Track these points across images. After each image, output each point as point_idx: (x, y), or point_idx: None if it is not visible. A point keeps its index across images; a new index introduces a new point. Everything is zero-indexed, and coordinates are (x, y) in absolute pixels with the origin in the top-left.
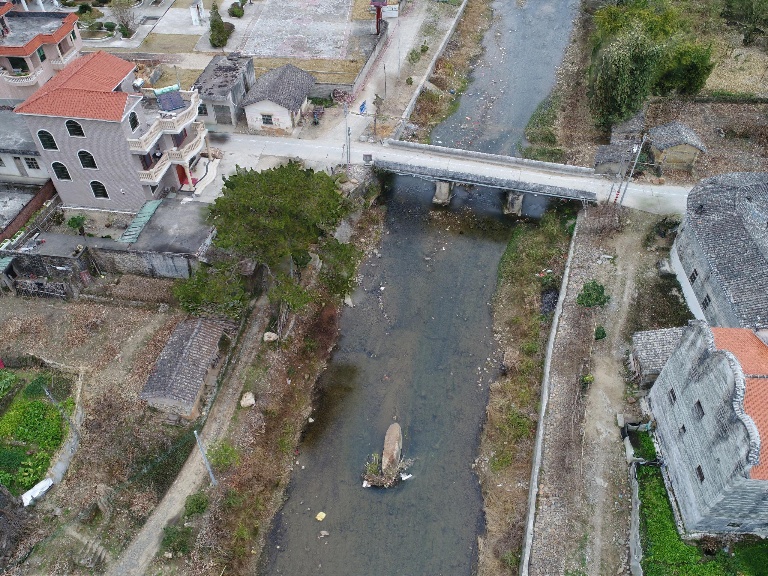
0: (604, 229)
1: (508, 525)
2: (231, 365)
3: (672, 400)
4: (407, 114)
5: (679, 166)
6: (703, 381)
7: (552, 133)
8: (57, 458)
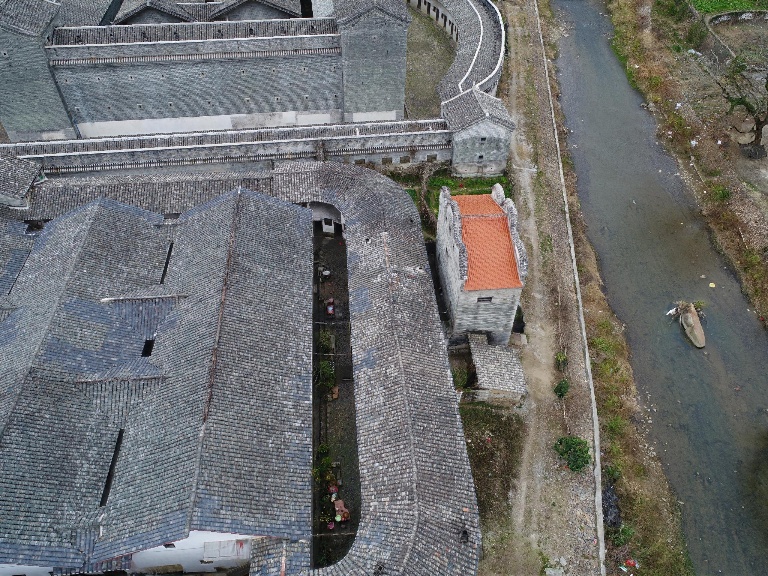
0: None
1: None
2: None
3: None
4: None
5: None
6: None
7: None
8: None
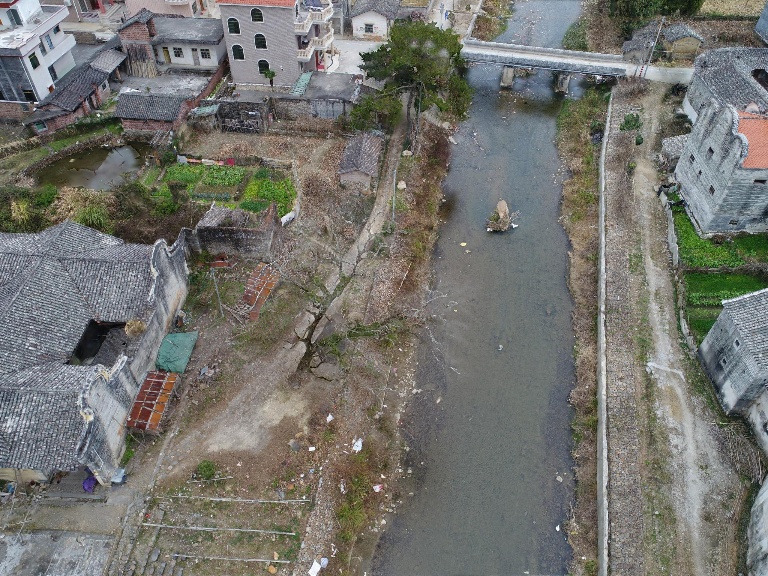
0: (634, 91)
1: (587, 244)
2: (384, 169)
3: (692, 161)
4: (471, 29)
5: (685, 56)
6: (713, 133)
7: (584, 43)
8: (296, 202)
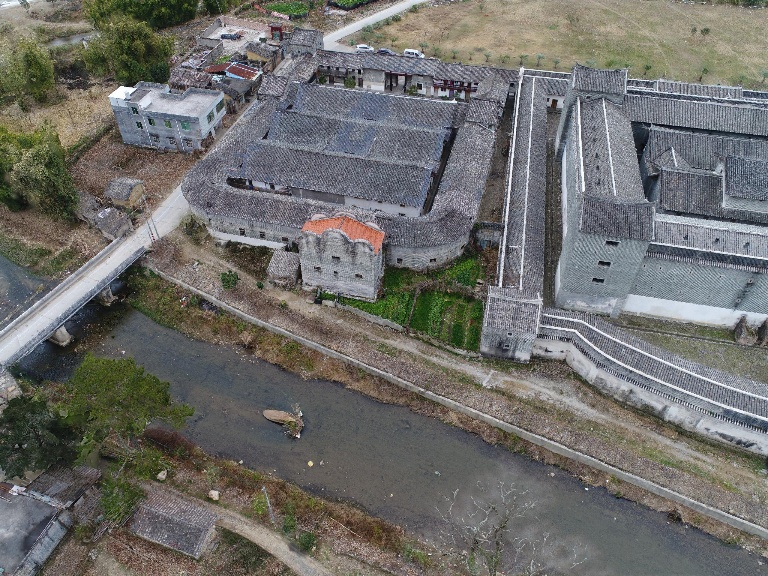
0: None
1: (345, 371)
2: None
3: (319, 270)
4: None
5: None
6: (327, 249)
7: None
8: None
